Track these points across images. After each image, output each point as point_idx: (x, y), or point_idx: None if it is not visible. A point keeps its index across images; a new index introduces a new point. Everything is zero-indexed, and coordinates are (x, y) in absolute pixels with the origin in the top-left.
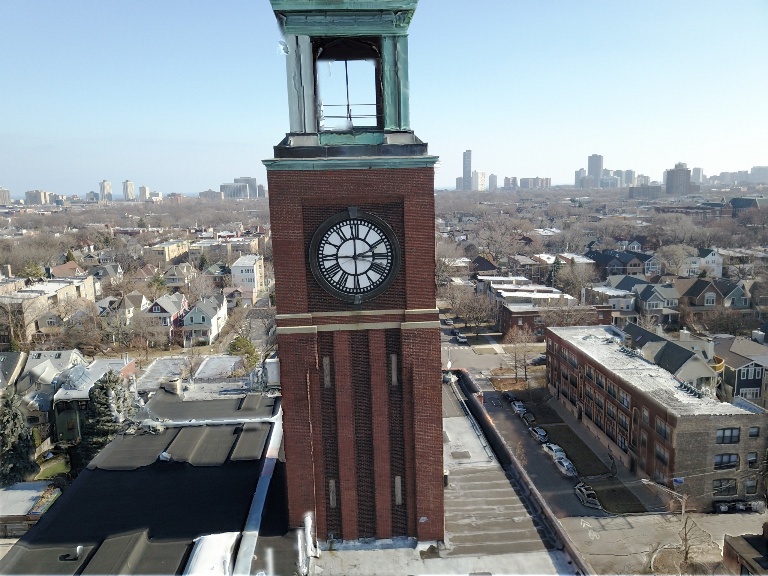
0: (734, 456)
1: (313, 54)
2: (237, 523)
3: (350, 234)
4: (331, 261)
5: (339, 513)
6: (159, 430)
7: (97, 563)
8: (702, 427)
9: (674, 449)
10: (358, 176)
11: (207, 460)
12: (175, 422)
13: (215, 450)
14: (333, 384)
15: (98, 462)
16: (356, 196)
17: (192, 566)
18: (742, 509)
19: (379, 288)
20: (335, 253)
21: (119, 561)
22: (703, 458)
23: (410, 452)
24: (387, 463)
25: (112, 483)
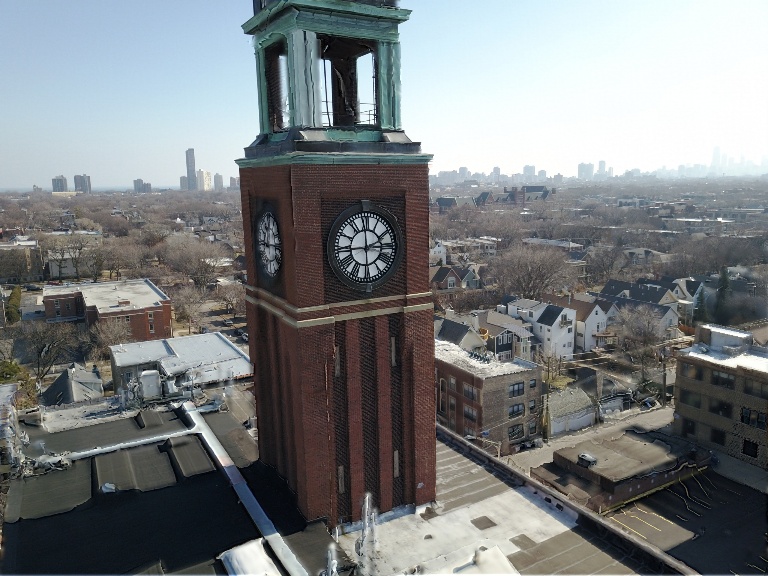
0: (521, 406)
1: (321, 51)
2: (246, 532)
3: (362, 226)
4: (346, 252)
5: (347, 497)
6: (67, 464)
7: None
8: (500, 386)
9: (482, 407)
10: (370, 171)
11: (154, 483)
12: (80, 453)
13: (154, 471)
14: (343, 372)
15: (15, 513)
16: (368, 190)
17: None
18: (529, 447)
19: (385, 276)
20: (348, 245)
21: None
22: (501, 411)
23: (408, 426)
24: (390, 440)
25: (57, 530)
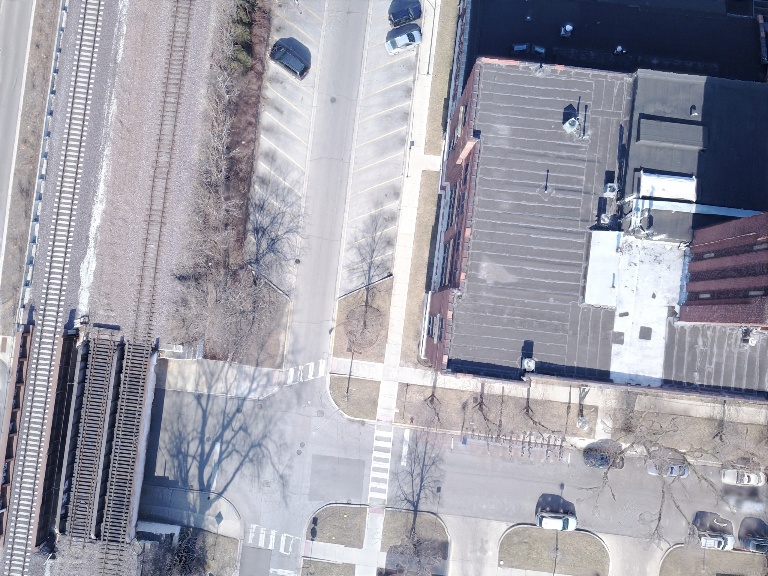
0: None
1: None
2: (709, 200)
3: None
4: None
5: None
6: None
7: (679, 128)
8: None
9: None
10: None
11: None
12: None
13: None
14: None
15: None
16: None
17: (667, 179)
18: None
19: None
20: None
21: (676, 140)
22: None
23: None
24: (714, 288)
25: None
